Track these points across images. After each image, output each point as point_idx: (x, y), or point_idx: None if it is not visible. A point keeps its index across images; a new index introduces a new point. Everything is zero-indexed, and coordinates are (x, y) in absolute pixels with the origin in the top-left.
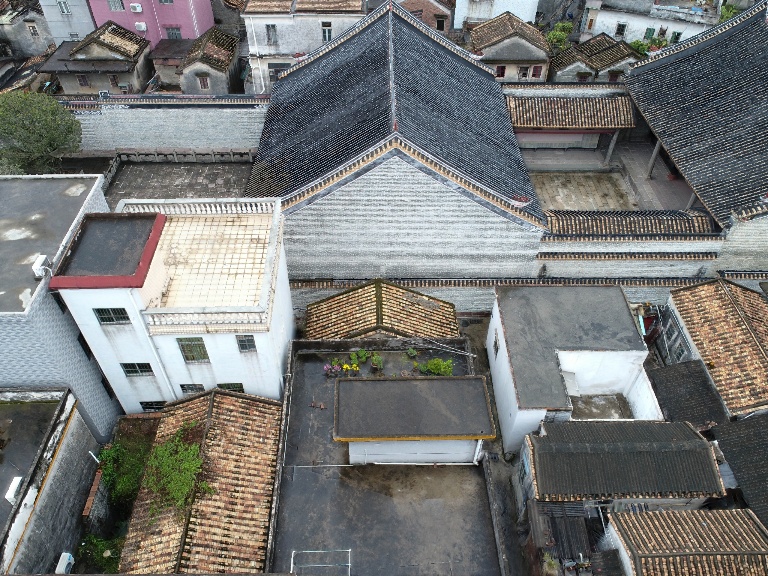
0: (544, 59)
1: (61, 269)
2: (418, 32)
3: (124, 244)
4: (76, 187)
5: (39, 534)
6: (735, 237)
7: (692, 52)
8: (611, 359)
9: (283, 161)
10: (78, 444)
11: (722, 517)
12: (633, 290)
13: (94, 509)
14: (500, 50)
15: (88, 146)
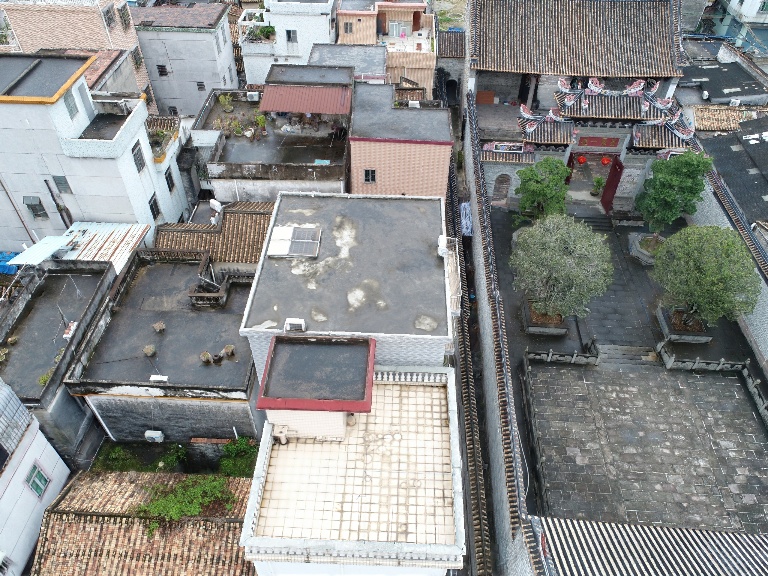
0: None
1: (291, 339)
2: None
3: (322, 380)
4: (431, 322)
5: (152, 408)
6: None
7: None
8: None
9: (691, 572)
10: (232, 415)
11: None
12: None
13: (203, 446)
14: None
15: (756, 331)
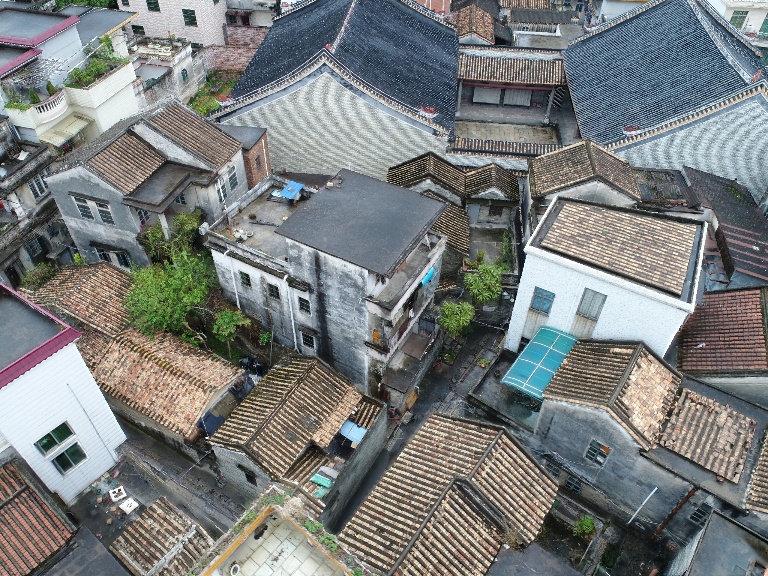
0: None
1: None
2: None
3: None
4: None
5: None
6: None
7: None
8: None
9: None
10: None
11: (513, 4)
12: None
13: None
14: None
15: None
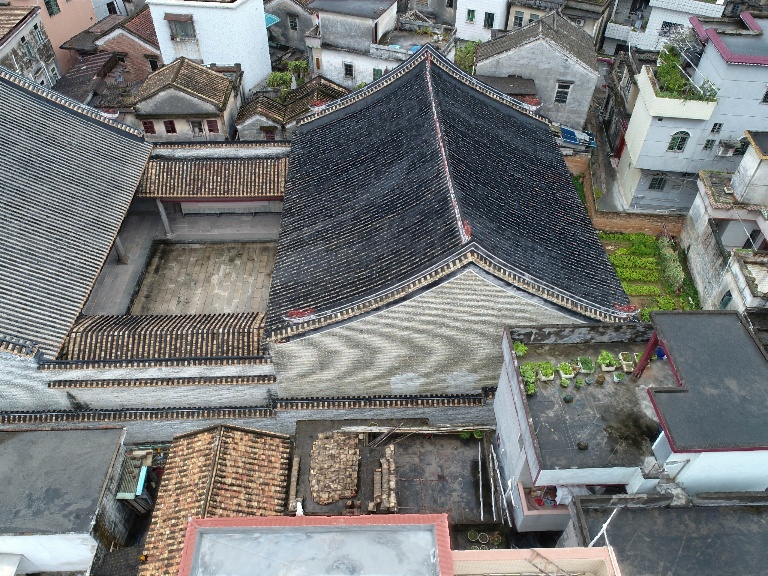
0: (215, 112)
1: None
2: (24, 90)
3: None
4: None
5: None
6: (284, 359)
7: (361, 107)
8: (50, 542)
9: None
10: None
11: None
12: (177, 422)
13: None
14: (159, 104)
15: None
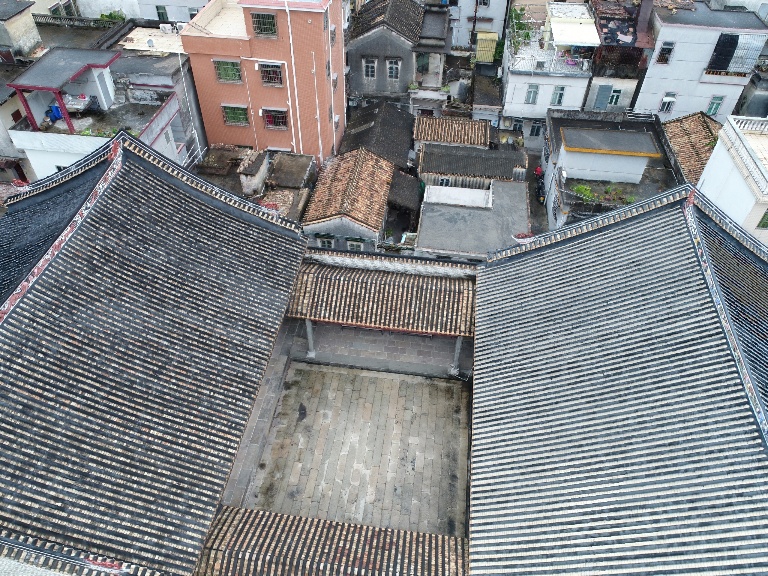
0: None
1: None
2: None
3: None
4: None
5: None
6: None
7: None
8: None
9: None
10: None
11: None
12: None
13: None
14: None
15: None
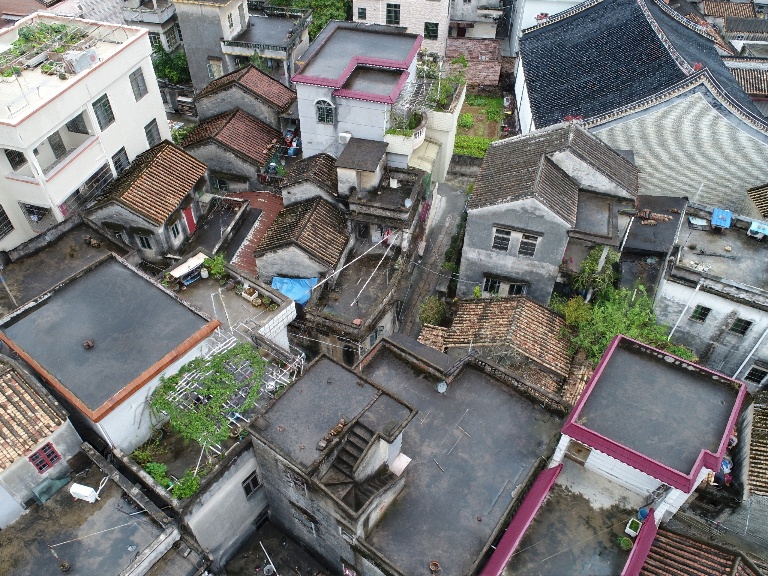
0: None
1: None
2: None
3: None
4: None
5: None
6: None
7: None
8: None
9: None
10: None
11: None
12: None
13: None
14: None
15: None
